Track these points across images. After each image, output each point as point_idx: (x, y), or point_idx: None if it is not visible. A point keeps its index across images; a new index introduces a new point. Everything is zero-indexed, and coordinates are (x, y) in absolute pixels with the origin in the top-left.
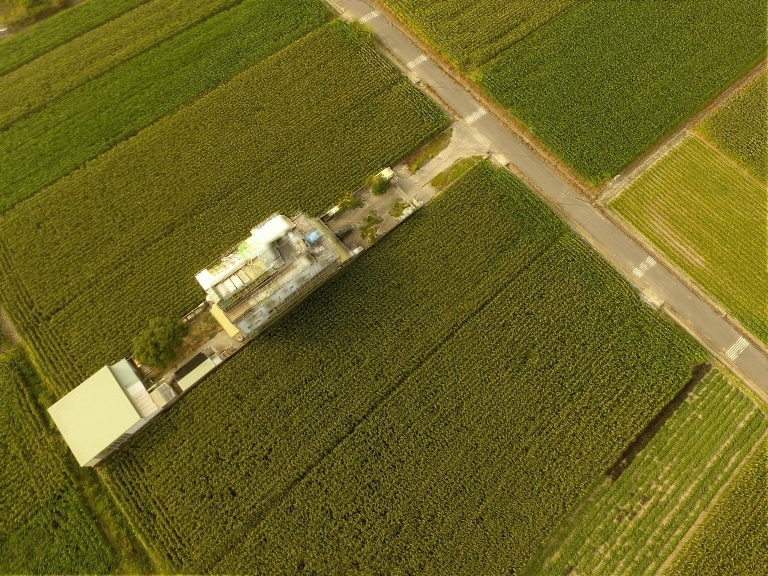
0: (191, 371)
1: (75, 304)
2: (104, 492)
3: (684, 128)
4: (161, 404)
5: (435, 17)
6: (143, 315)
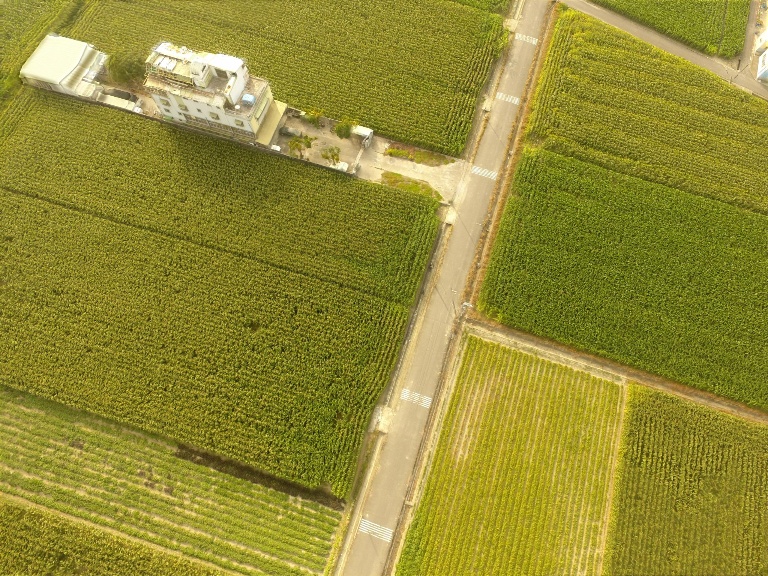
0: (113, 96)
1: (130, 5)
2: (10, 100)
3: (625, 376)
4: (78, 92)
5: (570, 85)
6: (142, 46)
